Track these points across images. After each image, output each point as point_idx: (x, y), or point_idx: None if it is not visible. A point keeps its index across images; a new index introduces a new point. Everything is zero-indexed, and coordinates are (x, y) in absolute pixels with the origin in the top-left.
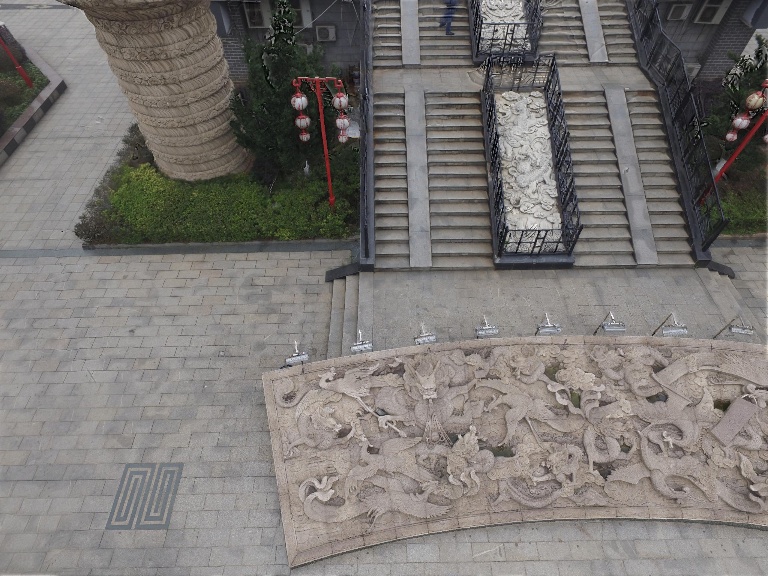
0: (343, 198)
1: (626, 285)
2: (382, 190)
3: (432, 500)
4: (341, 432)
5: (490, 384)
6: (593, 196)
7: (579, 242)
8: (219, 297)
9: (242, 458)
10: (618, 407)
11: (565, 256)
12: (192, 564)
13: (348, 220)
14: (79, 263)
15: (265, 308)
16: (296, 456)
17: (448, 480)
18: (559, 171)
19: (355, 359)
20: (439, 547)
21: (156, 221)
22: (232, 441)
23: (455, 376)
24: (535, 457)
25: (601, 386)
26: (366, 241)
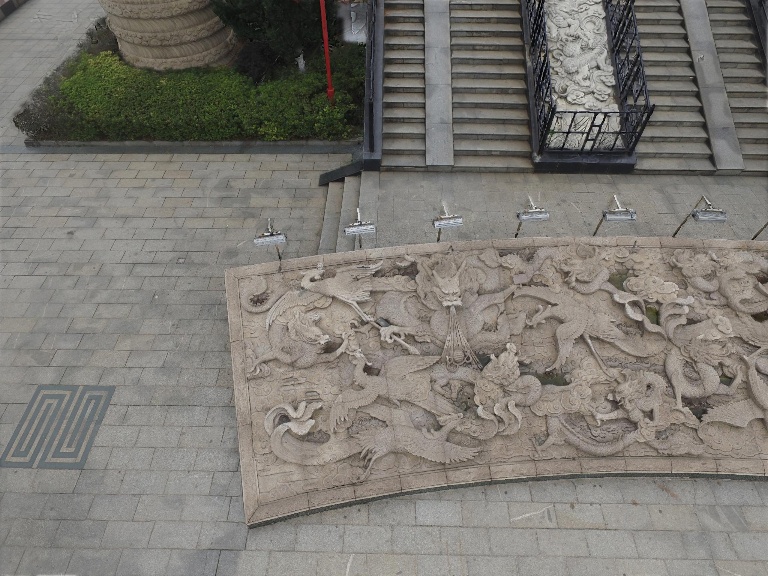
0: (344, 92)
1: (703, 193)
2: (393, 76)
3: (453, 440)
4: (328, 347)
5: (534, 292)
6: (659, 88)
7: (641, 142)
8: (185, 199)
9: (194, 383)
10: (712, 326)
11: (624, 156)
12: (110, 517)
13: (350, 119)
14: (18, 160)
15: (241, 212)
16: (264, 375)
17: (476, 414)
18: (617, 54)
19: (351, 256)
20: (461, 506)
21: (113, 109)
22: (183, 362)
23: (486, 281)
24: (598, 388)
25: (688, 298)
26: (371, 124)
